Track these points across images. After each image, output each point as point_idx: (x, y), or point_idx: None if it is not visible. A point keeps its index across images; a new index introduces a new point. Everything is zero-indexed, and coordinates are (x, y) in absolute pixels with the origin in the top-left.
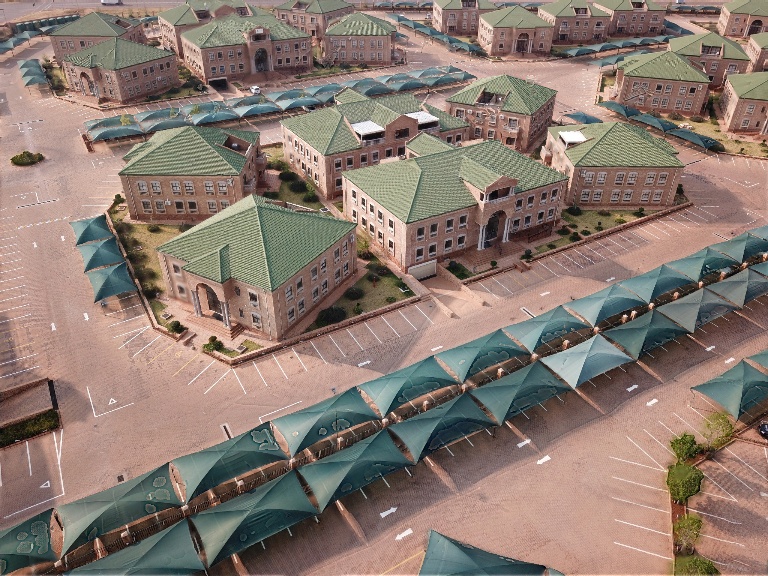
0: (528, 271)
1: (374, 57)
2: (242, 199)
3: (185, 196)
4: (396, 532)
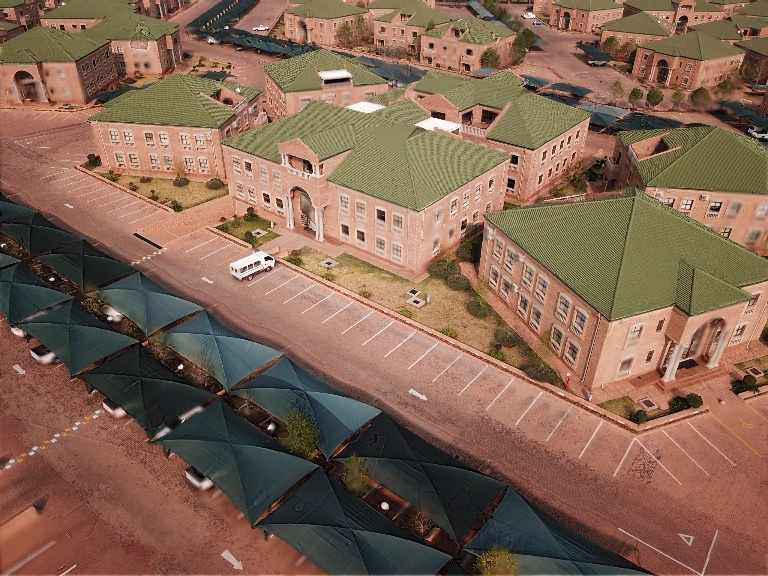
0: None
1: None
2: (668, 184)
3: None
4: None
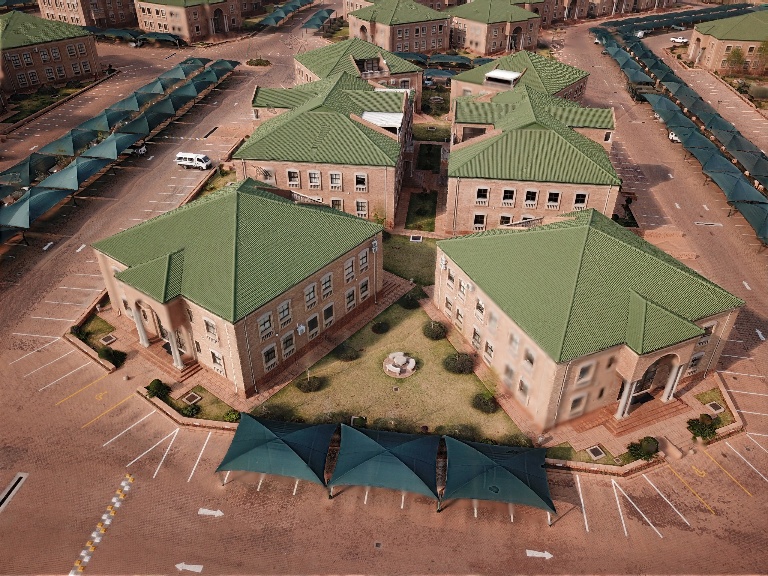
0: None
1: (78, 70)
2: (450, 251)
3: (320, 303)
4: None
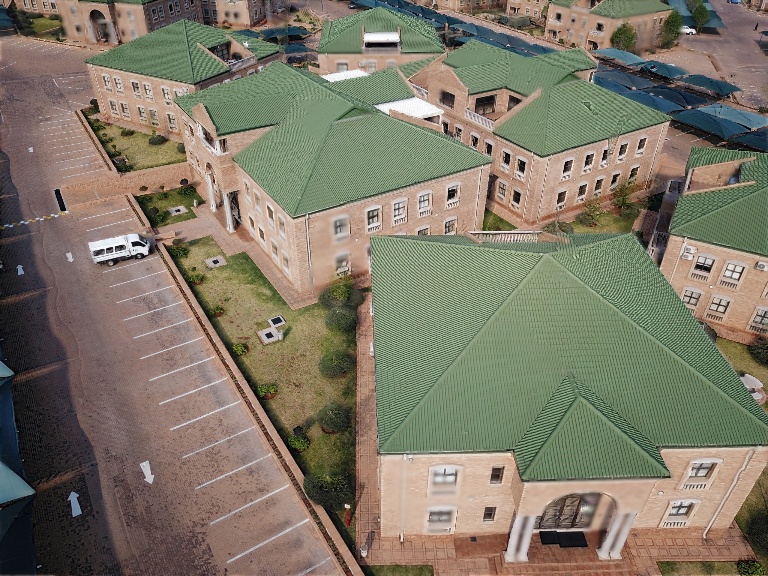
0: None
1: None
2: (705, 235)
3: None
4: None
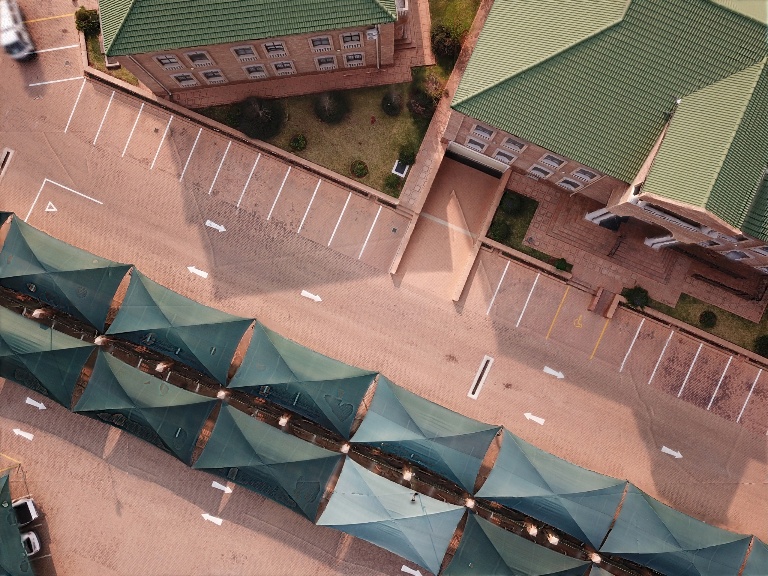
0: (600, 317)
1: None
2: None
3: None
4: (20, 425)
